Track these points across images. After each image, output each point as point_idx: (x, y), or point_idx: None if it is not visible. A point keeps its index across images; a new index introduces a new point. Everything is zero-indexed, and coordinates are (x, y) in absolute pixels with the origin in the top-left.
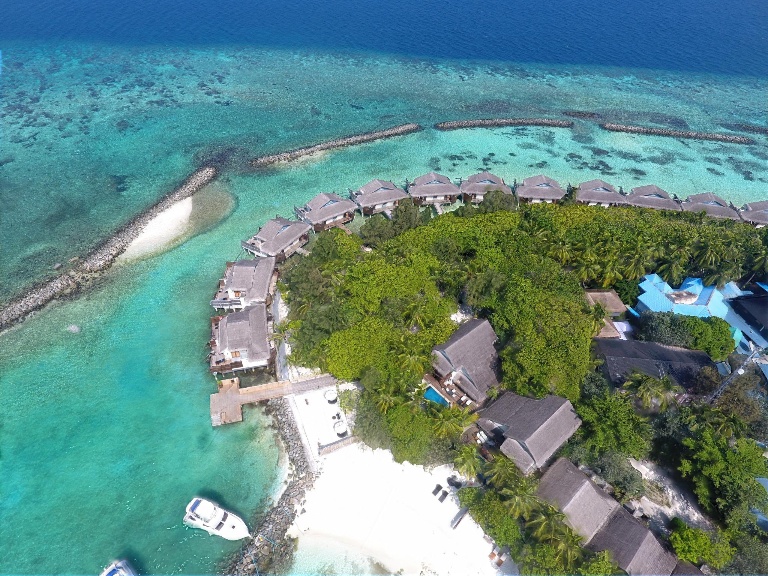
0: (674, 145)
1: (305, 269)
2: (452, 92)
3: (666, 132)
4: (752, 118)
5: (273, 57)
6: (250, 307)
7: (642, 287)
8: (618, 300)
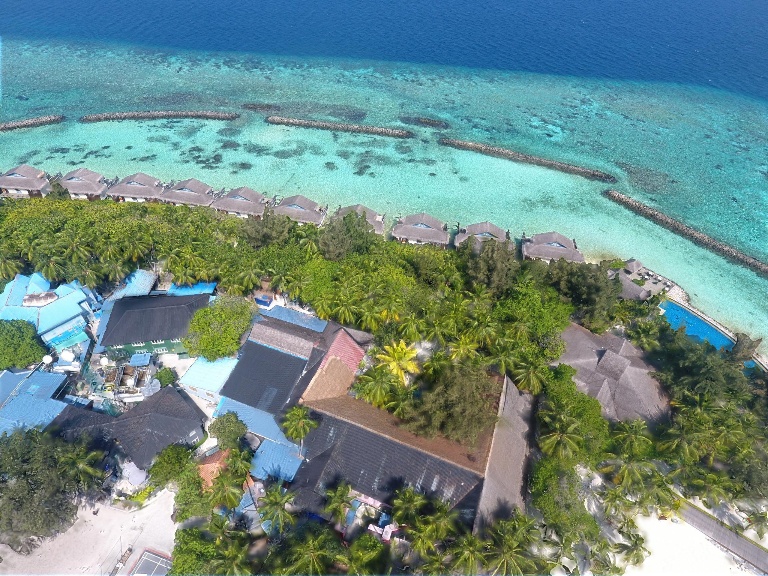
0: (322, 138)
1: None
2: (148, 84)
3: (327, 125)
4: (444, 111)
5: None
6: None
7: (5, 287)
8: None
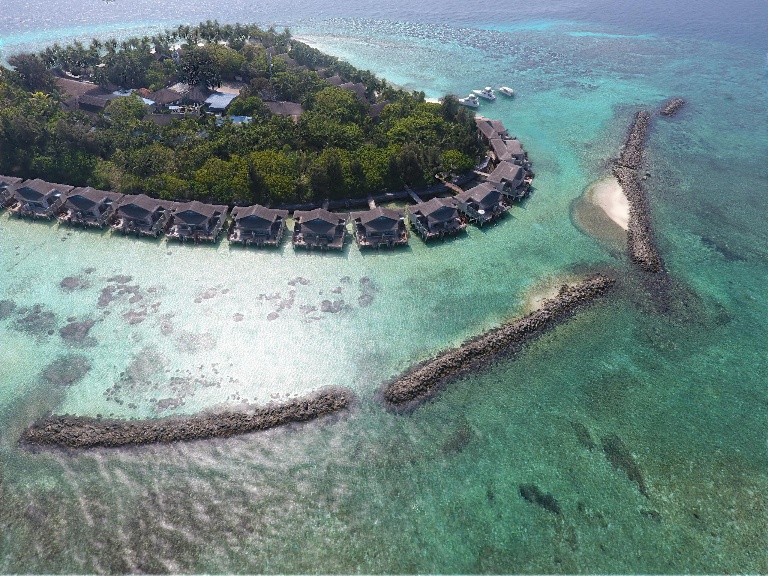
0: None
1: (469, 112)
2: None
3: None
4: None
5: None
6: (496, 134)
7: None
8: None
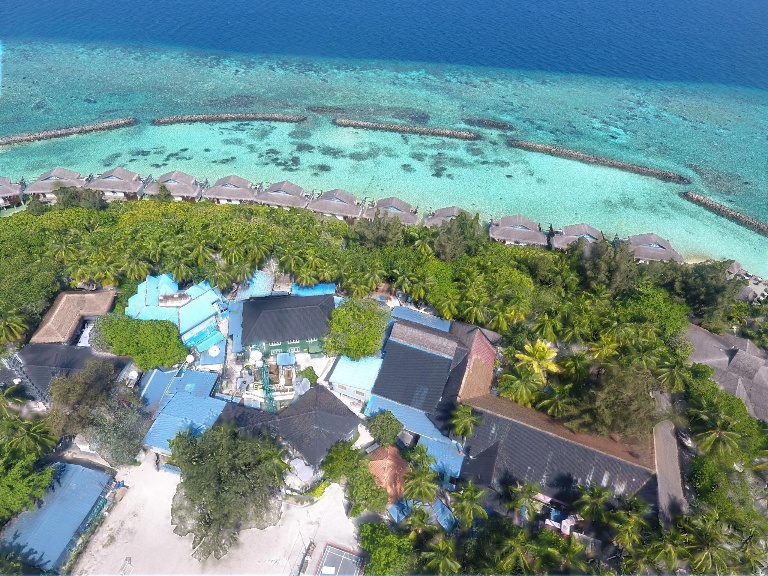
0: (392, 141)
1: None
2: (210, 86)
3: (394, 127)
4: (505, 113)
5: (54, 50)
6: None
7: (137, 288)
8: (99, 302)
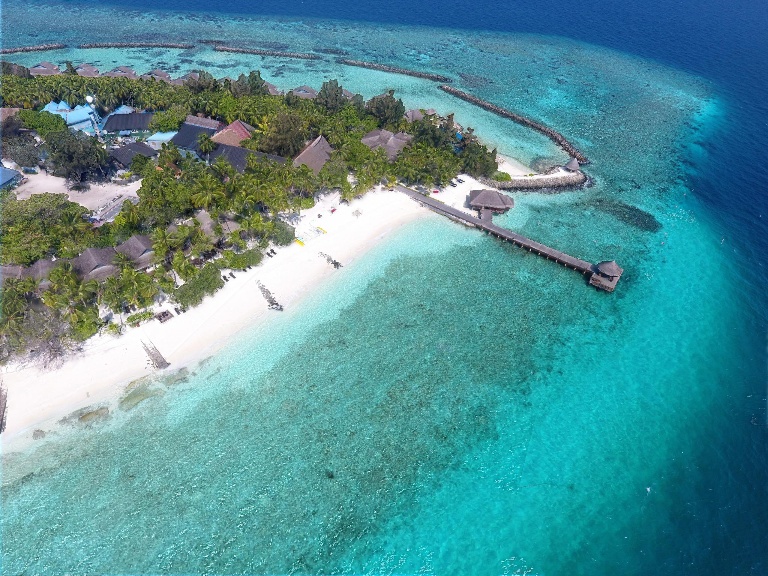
0: (253, 59)
1: None
2: (128, 28)
3: (258, 52)
4: (348, 46)
5: (8, 5)
6: None
7: None
8: None
